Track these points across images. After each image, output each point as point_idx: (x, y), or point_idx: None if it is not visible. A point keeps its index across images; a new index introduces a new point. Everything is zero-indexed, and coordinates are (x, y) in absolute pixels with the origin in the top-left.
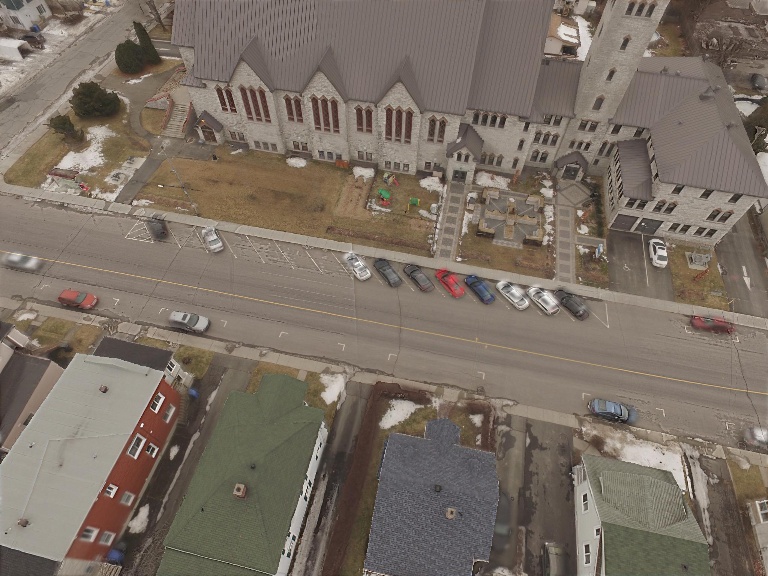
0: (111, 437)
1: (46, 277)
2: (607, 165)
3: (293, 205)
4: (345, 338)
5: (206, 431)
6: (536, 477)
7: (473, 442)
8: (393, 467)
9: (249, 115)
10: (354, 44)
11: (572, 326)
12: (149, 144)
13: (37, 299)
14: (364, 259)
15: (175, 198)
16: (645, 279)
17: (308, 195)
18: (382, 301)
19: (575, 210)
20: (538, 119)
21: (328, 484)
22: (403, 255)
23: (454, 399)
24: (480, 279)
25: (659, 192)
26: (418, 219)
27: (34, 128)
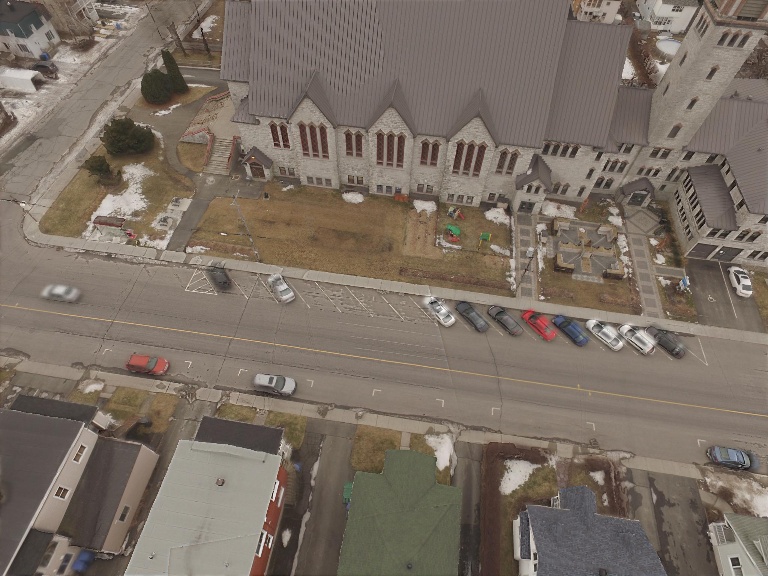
0: (240, 539)
1: (106, 340)
2: (674, 190)
3: (359, 245)
4: (442, 393)
5: (316, 510)
6: (671, 538)
7: (600, 503)
8: (548, 550)
9: (305, 151)
10: (424, 77)
11: (671, 366)
12: (192, 183)
13: (100, 366)
14: (444, 302)
15: (232, 243)
16: (732, 310)
17: (372, 234)
18: (473, 349)
19: (647, 238)
20: (613, 149)
21: (459, 563)
22: (484, 296)
23: (569, 455)
24: (567, 318)
25: (745, 222)
26: (492, 255)
27: (62, 169)
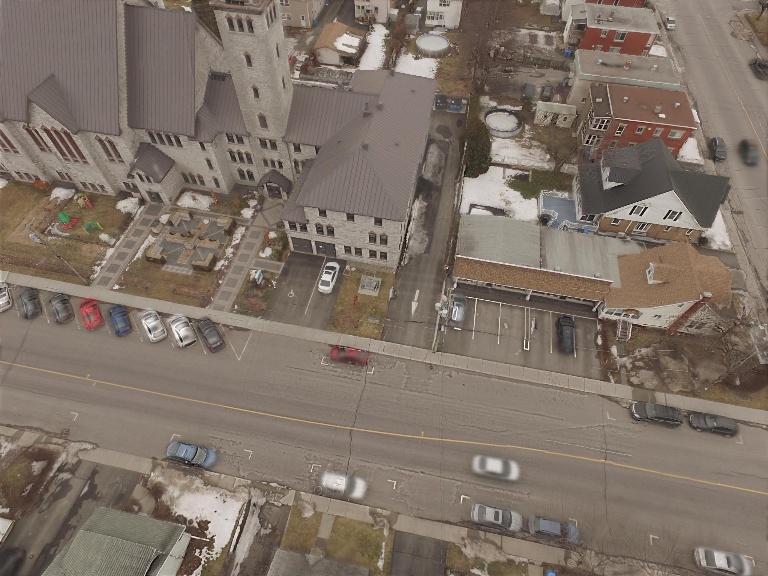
0: None
1: None
2: None
3: None
4: None
5: None
6: (72, 531)
7: (19, 493)
8: None
9: None
10: None
11: (200, 359)
12: None
13: None
14: (14, 288)
15: None
16: (305, 306)
17: None
18: (7, 335)
19: (268, 231)
20: (206, 138)
21: None
22: (58, 283)
23: (28, 444)
24: (129, 309)
25: (308, 215)
26: (93, 244)
27: None
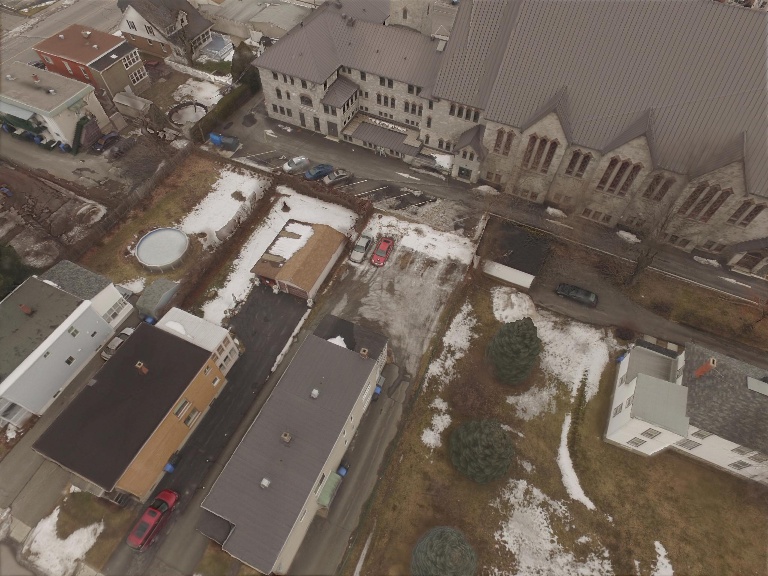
0: None
1: None
2: None
3: None
4: None
5: None
6: None
7: None
8: None
9: None
10: None
11: None
12: None
13: None
14: None
15: None
16: None
17: None
18: None
19: None
20: None
21: None
22: None
23: None
24: None
25: None
26: None
27: None
